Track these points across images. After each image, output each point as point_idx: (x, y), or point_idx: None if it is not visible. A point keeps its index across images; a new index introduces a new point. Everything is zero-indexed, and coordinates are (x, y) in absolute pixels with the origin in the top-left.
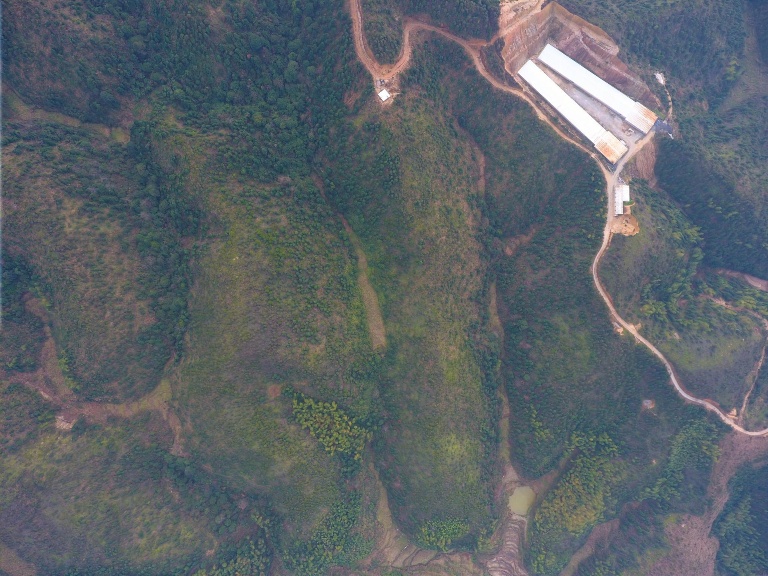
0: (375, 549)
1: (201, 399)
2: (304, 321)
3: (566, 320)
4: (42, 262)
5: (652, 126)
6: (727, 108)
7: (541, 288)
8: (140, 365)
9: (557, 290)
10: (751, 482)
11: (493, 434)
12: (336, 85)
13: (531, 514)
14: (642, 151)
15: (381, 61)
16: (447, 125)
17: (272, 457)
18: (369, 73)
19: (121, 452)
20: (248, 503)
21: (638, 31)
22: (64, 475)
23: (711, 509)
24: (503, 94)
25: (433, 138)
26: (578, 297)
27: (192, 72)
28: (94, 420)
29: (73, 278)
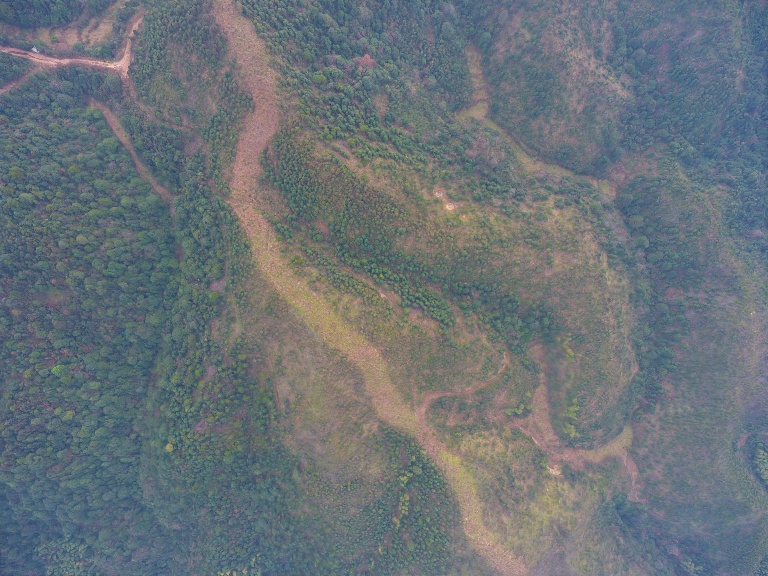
0: None
1: (695, 449)
2: None
3: None
4: (582, 314)
5: None
6: None
7: None
8: (621, 412)
9: None
10: None
11: None
12: None
13: None
14: None
15: None
16: None
17: (751, 508)
18: None
19: (606, 499)
20: None
21: None
22: (579, 523)
23: None
24: None
25: None
26: None
27: None
28: (574, 466)
29: (610, 330)
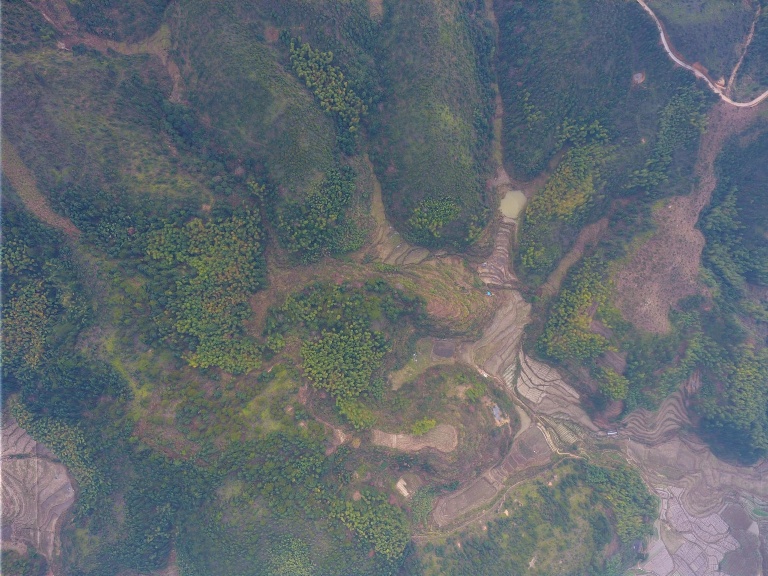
0: (368, 243)
1: (200, 20)
2: None
3: None
4: None
5: None
6: None
7: None
8: None
9: None
10: (738, 172)
11: (486, 122)
12: None
13: (522, 215)
14: None
15: None
16: None
17: (269, 89)
18: None
19: (121, 78)
20: (244, 171)
21: None
22: (65, 77)
23: (698, 188)
24: None
25: None
26: None
27: None
28: None
29: None
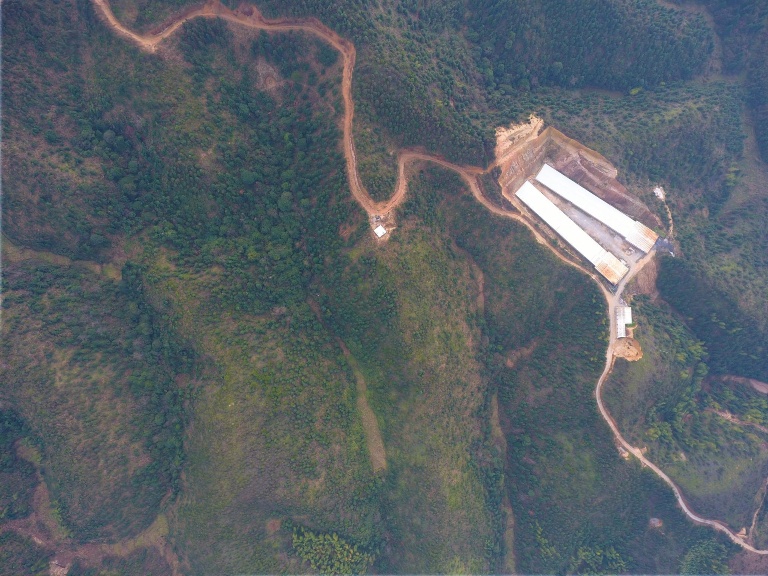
0: None
1: (198, 543)
2: (302, 457)
3: (570, 440)
4: (33, 418)
5: (653, 246)
6: (727, 210)
7: (544, 407)
8: (135, 506)
9: (560, 410)
10: None
11: (498, 550)
12: (331, 219)
13: None
14: (643, 270)
15: (376, 200)
16: (444, 248)
17: None
18: (364, 210)
19: None
20: None
21: (636, 150)
22: None
23: None
24: (501, 219)
25: (431, 267)
26: (582, 419)
27: (184, 211)
28: (89, 563)
29: (65, 433)
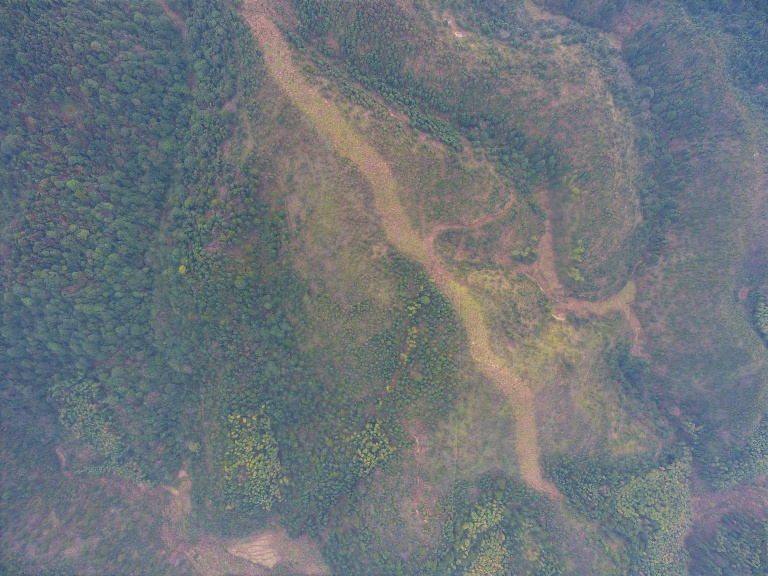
0: None
1: (697, 294)
2: None
3: None
4: (588, 149)
5: None
6: None
7: None
8: (625, 262)
9: None
10: None
11: None
12: None
13: None
14: None
15: None
16: None
17: (752, 355)
18: None
19: (610, 345)
20: (679, 410)
21: None
22: (584, 360)
23: None
24: None
25: None
26: None
27: None
28: (578, 315)
29: None
